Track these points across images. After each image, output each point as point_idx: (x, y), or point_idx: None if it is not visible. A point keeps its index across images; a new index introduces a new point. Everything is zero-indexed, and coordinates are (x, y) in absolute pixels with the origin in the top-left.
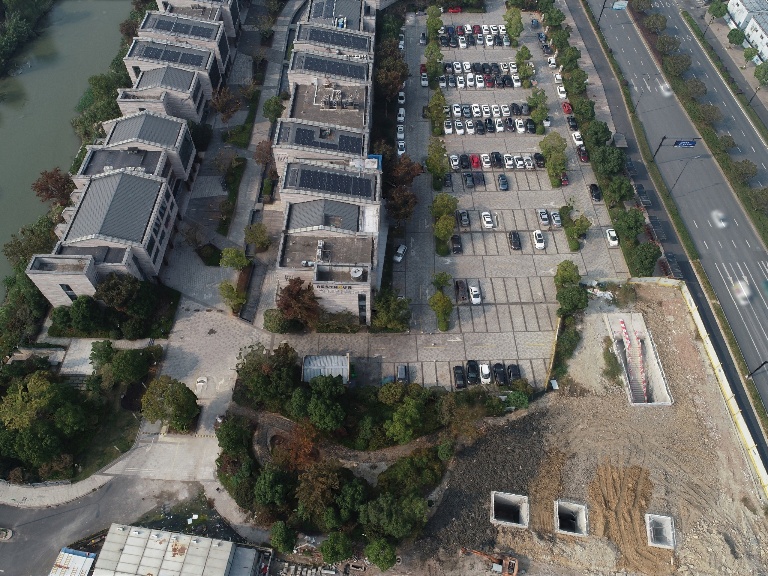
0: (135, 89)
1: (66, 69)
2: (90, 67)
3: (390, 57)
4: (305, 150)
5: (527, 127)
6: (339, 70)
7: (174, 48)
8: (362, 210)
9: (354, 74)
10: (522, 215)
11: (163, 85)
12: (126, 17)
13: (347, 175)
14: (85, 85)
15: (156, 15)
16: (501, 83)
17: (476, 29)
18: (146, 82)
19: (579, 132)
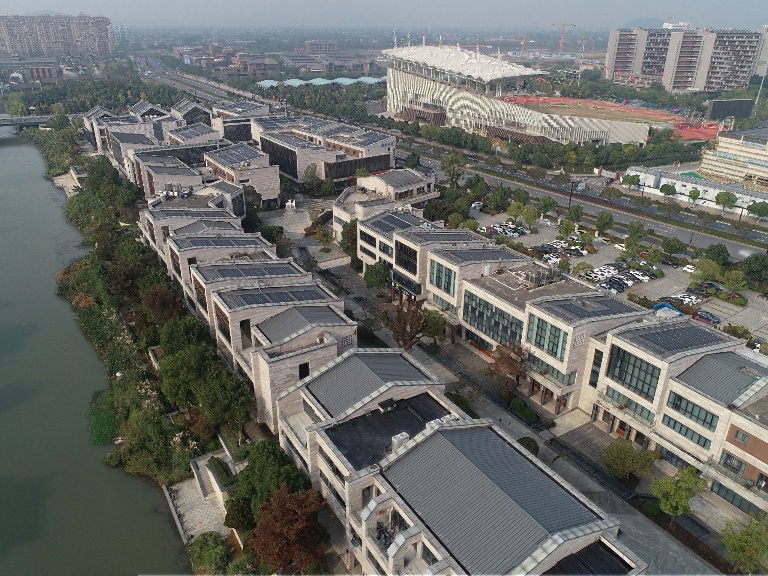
0: (277, 342)
1: (22, 401)
2: (66, 385)
3: (502, 243)
4: (604, 319)
5: (647, 275)
6: (492, 256)
7: (272, 290)
8: (741, 354)
9: (508, 257)
10: (765, 335)
11: (320, 323)
12: (65, 321)
13: (673, 328)
14: (78, 408)
15: (206, 267)
16: (576, 253)
17: (491, 228)
18: (279, 332)
19: (682, 267)
